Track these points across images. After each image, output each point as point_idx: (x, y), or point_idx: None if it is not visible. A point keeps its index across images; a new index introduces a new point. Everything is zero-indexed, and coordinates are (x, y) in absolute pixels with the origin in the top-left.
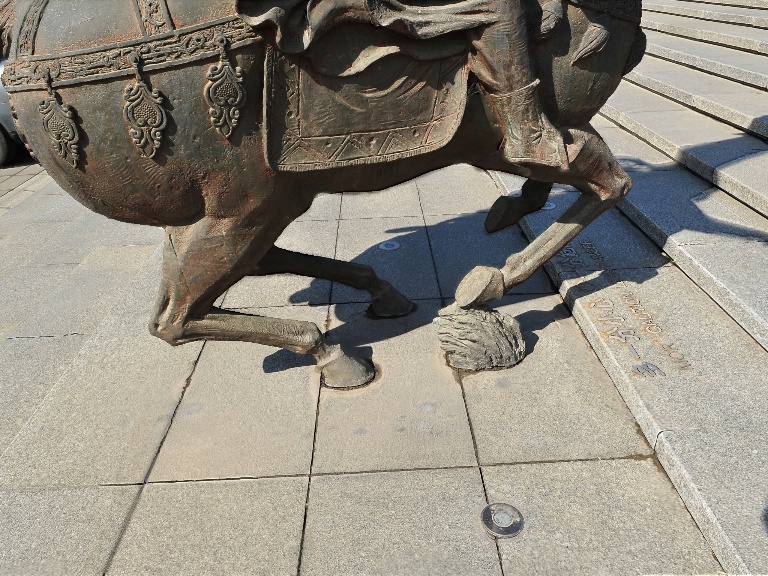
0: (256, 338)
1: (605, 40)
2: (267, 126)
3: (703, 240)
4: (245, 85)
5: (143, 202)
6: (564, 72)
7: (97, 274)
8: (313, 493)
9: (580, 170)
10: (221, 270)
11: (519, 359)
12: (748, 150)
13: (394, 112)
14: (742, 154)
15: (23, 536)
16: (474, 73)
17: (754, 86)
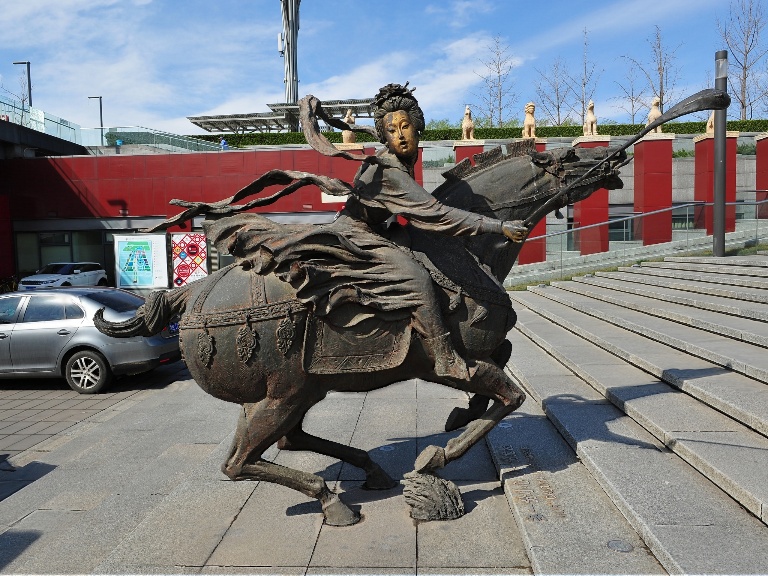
0: (284, 481)
1: (486, 314)
2: (305, 350)
3: (600, 446)
4: (296, 329)
5: (235, 387)
6: (466, 329)
7: (175, 460)
8: (308, 575)
9: (487, 385)
10: (270, 430)
11: (460, 515)
12: (656, 392)
13: (372, 346)
14: (649, 394)
15: None
16: (414, 328)
17: (679, 349)
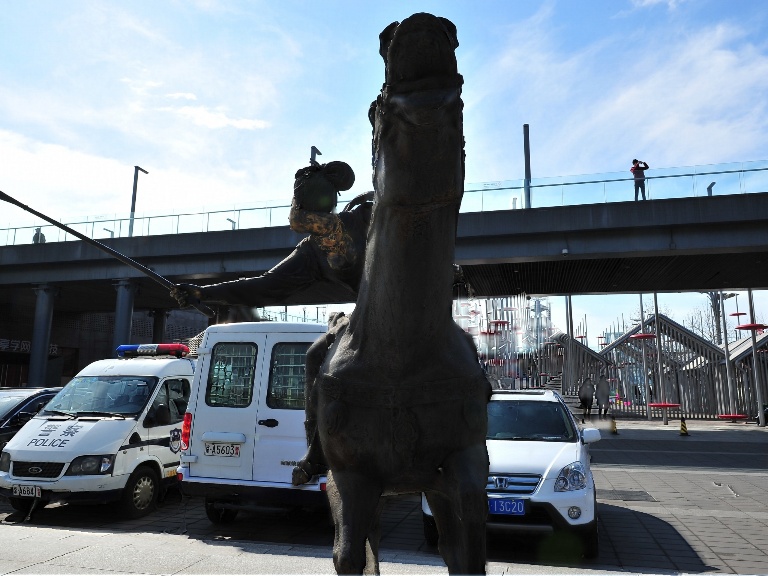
0: None
1: None
2: None
3: None
4: None
5: None
6: None
7: None
8: None
9: None
10: None
11: None
12: None
13: None
14: None
15: (310, 573)
16: None
17: None
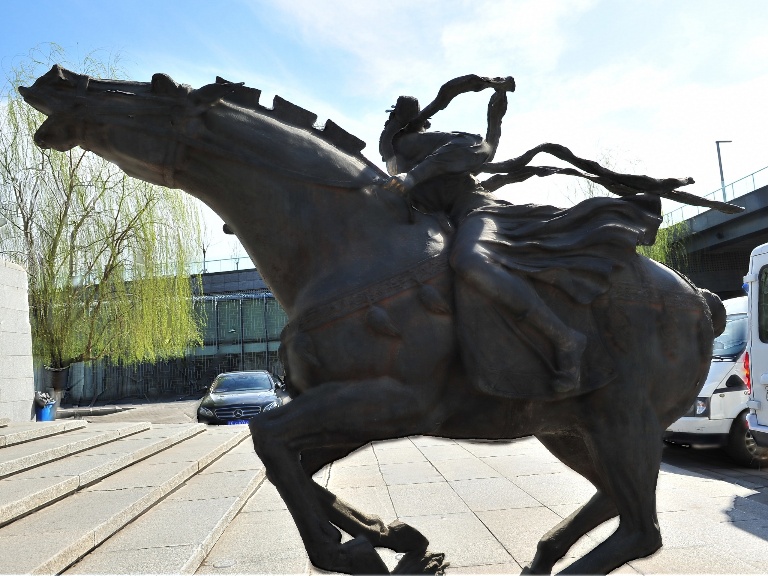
0: None
1: None
2: None
3: None
4: None
5: None
6: None
7: None
8: None
9: None
10: None
11: None
12: None
13: None
14: None
15: None
16: None
17: None
